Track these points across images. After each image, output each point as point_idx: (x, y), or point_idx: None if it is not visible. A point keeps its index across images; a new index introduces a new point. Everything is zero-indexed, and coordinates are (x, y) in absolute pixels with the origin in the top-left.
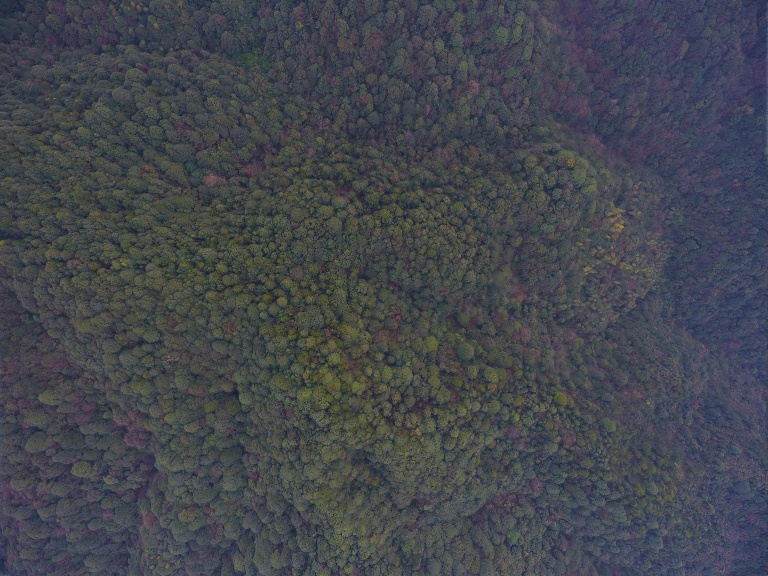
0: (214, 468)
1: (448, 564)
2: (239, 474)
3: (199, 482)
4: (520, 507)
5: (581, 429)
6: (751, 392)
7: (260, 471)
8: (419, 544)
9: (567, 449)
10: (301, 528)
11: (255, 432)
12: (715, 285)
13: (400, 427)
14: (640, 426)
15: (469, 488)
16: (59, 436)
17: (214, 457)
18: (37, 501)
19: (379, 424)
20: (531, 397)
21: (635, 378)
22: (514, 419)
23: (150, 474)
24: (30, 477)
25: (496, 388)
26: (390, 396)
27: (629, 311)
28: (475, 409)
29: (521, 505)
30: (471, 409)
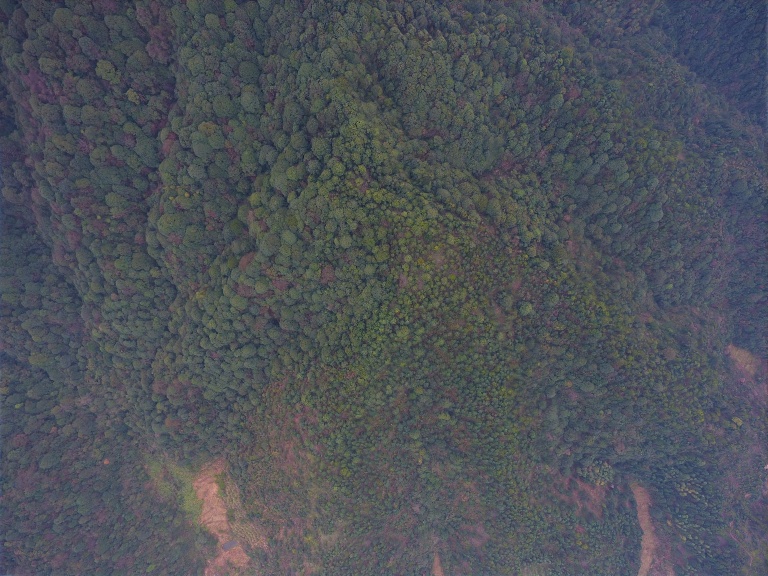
0: (233, 80)
1: (457, 194)
2: (257, 95)
3: (219, 86)
4: (526, 174)
5: (586, 84)
6: (750, 127)
7: (277, 87)
8: (429, 172)
9: (572, 103)
10: (317, 135)
11: (273, 44)
12: (717, 8)
13: (413, 35)
14: (643, 111)
15: (478, 128)
16: (85, 18)
17: (233, 63)
18: (63, 96)
19: (393, 25)
20: (538, 45)
21: (638, 66)
22: (522, 61)
23: (170, 104)
24: (57, 61)
25: (505, 29)
26: (403, 10)
27: (633, 32)
28: (485, 38)
29: (527, 173)
30: (481, 41)
